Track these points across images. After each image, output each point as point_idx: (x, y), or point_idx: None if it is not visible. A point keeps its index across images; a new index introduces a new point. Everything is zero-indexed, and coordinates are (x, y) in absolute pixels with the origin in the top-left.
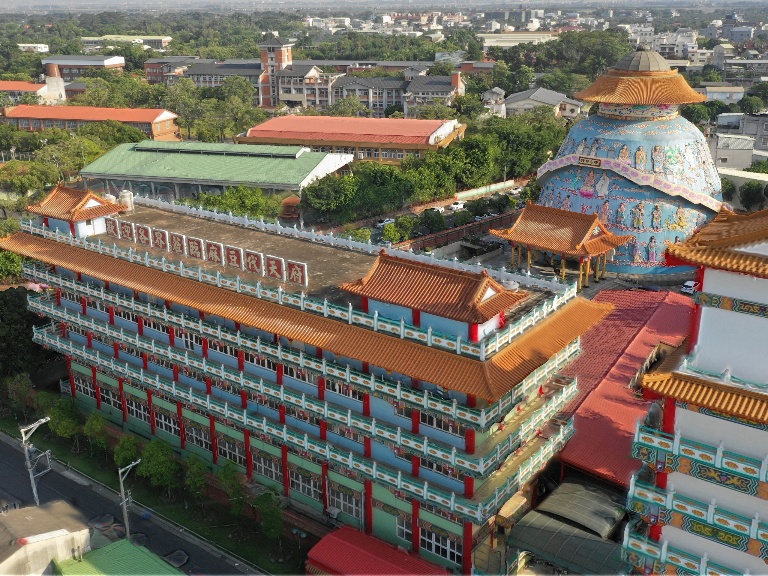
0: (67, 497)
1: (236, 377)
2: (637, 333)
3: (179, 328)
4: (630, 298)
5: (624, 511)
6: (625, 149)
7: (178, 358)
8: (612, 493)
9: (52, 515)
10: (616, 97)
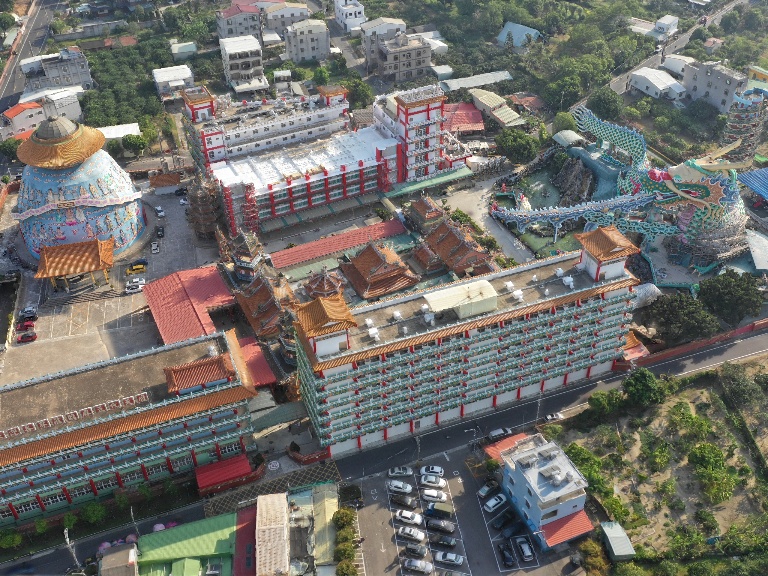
0: (57, 561)
1: (118, 453)
2: (195, 309)
3: (75, 453)
4: (163, 286)
5: (271, 392)
6: (82, 189)
7: (74, 466)
8: (263, 389)
9: (116, 552)
10: (61, 160)
